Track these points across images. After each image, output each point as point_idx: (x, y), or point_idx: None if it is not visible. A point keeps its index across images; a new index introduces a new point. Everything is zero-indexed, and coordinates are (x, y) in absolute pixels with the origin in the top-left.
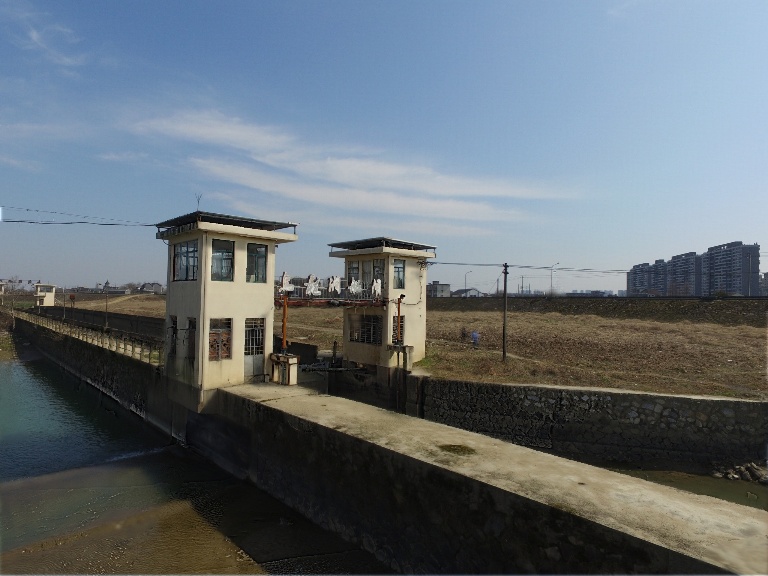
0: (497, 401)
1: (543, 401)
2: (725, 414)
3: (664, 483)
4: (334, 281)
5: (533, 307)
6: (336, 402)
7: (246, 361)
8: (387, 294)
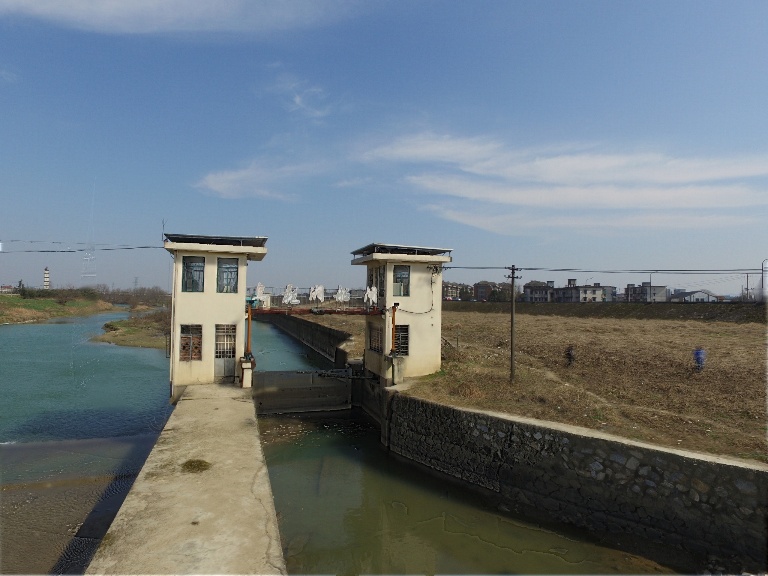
0: (448, 427)
1: (492, 433)
2: (739, 488)
3: (600, 568)
4: (316, 290)
5: (731, 315)
6: (235, 407)
7: (217, 363)
8: (385, 302)
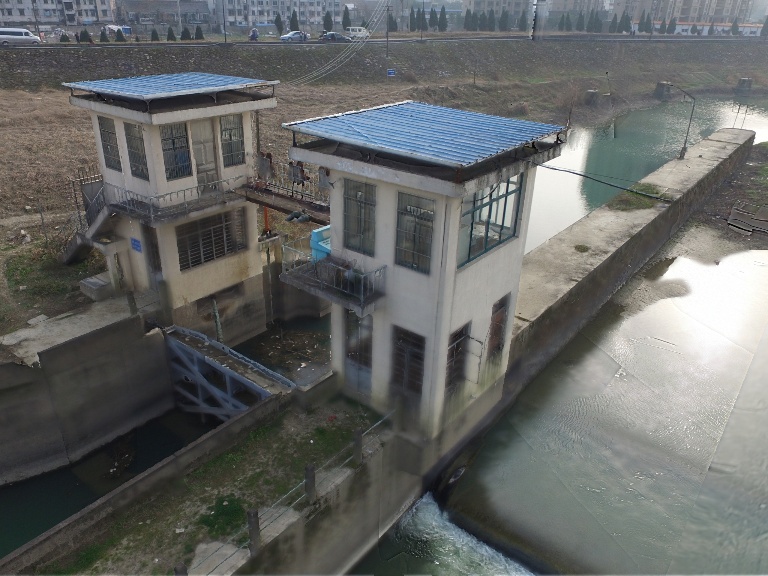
0: None
1: None
2: None
3: None
4: None
5: None
6: None
7: None
8: None
